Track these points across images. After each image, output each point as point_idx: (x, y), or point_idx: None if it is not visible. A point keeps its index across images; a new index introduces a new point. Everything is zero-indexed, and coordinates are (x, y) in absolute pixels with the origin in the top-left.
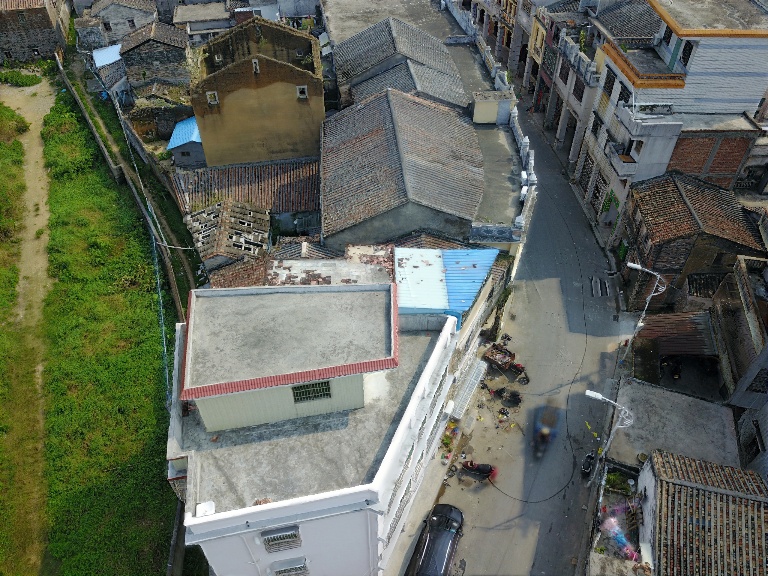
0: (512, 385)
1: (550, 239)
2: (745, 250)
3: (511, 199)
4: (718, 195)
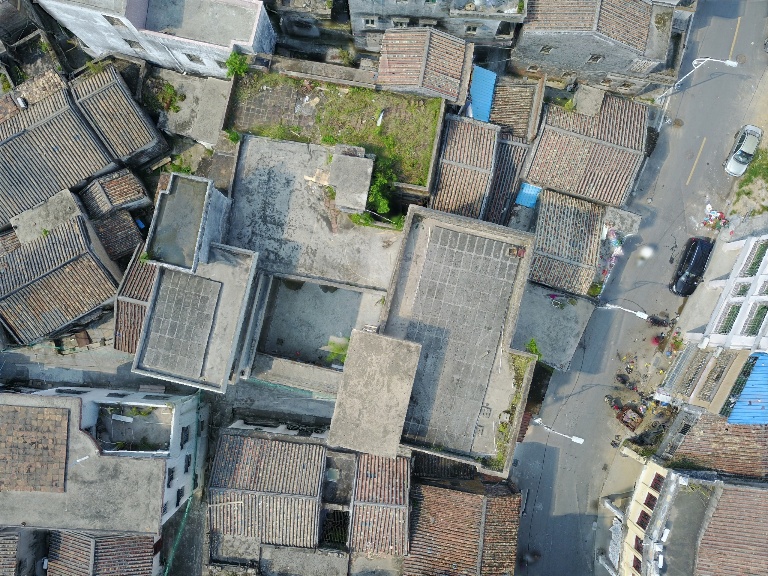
0: (619, 395)
1: (551, 572)
2: (439, 486)
3: (670, 534)
4: (429, 569)
